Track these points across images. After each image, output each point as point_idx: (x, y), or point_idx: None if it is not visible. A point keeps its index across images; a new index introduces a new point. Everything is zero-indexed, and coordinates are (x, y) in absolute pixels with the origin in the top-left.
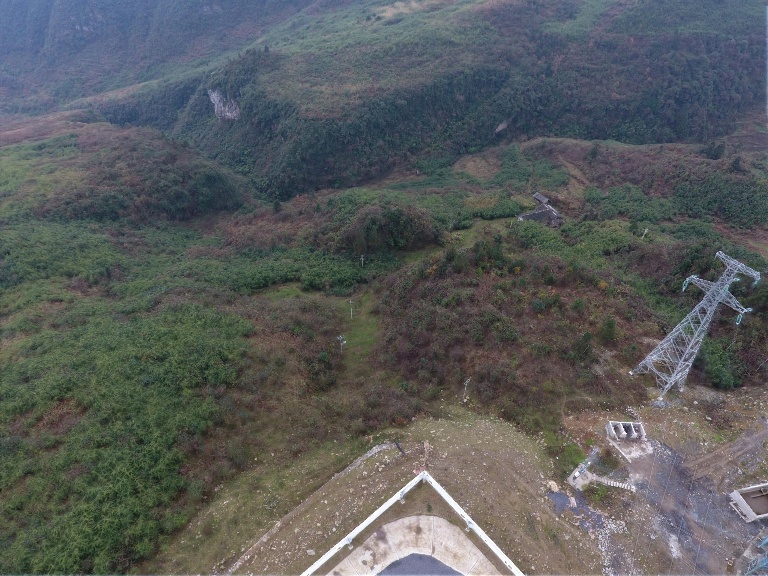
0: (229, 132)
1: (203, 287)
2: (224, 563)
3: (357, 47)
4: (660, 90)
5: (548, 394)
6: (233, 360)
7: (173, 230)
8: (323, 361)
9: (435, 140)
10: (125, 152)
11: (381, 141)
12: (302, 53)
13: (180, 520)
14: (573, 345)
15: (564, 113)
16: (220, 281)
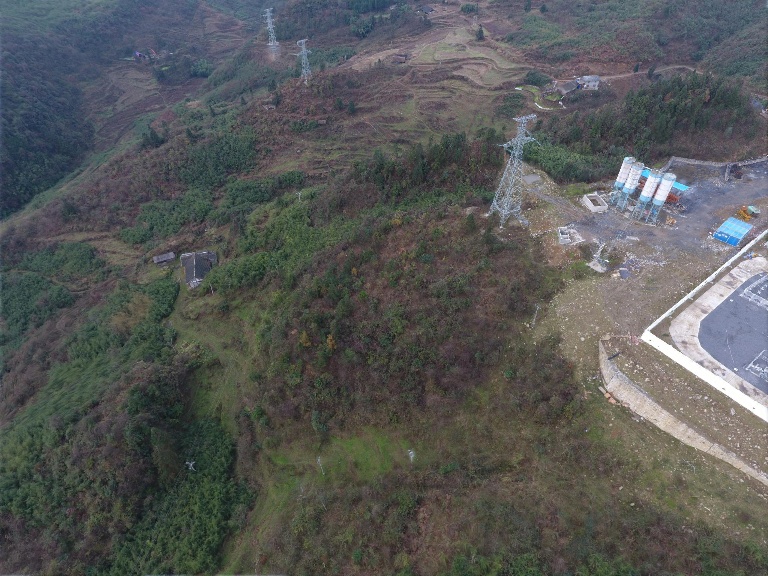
0: None
1: None
2: (762, 494)
3: None
4: (7, 128)
5: None
6: None
7: None
8: None
9: None
10: None
11: None
12: None
13: (755, 543)
14: (487, 243)
15: None
16: None
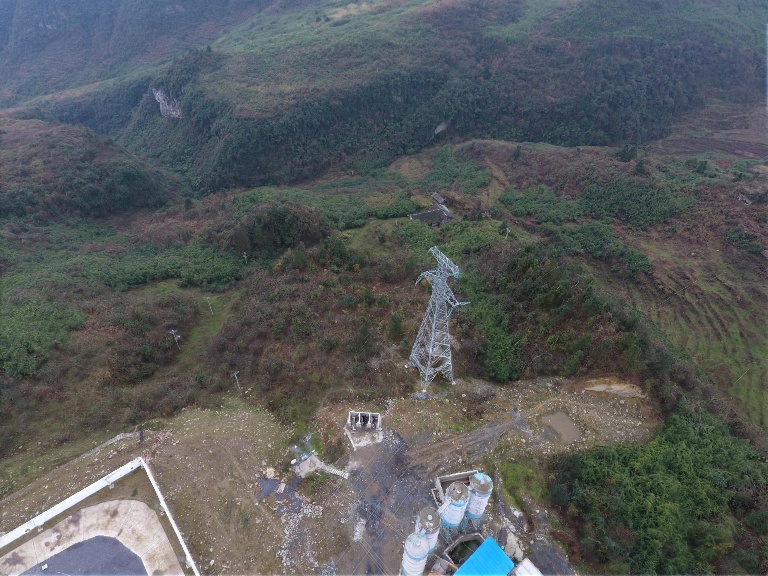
0: (173, 131)
1: (75, 282)
2: None
3: (297, 48)
4: (593, 94)
5: (316, 386)
6: (39, 352)
7: (84, 227)
8: (142, 354)
9: (372, 141)
10: (43, 149)
11: (315, 141)
12: (244, 53)
13: None
14: (355, 339)
15: (502, 115)
16: (97, 277)
